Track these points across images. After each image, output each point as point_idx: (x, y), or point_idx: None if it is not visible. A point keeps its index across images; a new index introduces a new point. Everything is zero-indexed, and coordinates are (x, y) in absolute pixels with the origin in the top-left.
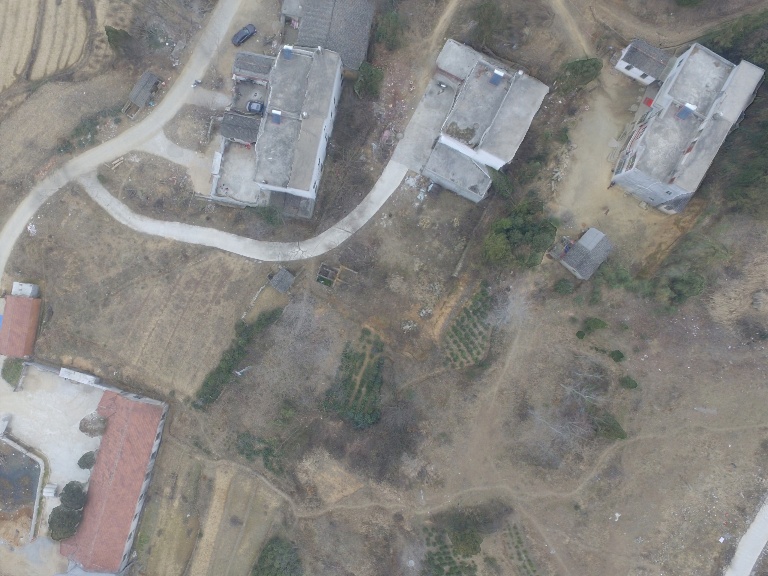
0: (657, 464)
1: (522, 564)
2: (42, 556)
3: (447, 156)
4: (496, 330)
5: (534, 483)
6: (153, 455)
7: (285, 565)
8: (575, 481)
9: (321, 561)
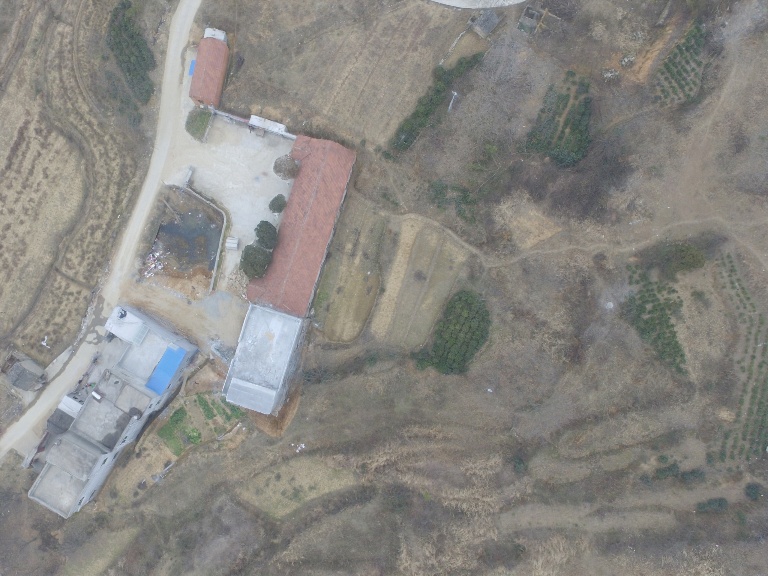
0: None
1: (735, 293)
2: (221, 308)
3: None
4: (709, 67)
5: (751, 210)
6: (341, 205)
7: (474, 314)
8: None
9: (510, 311)
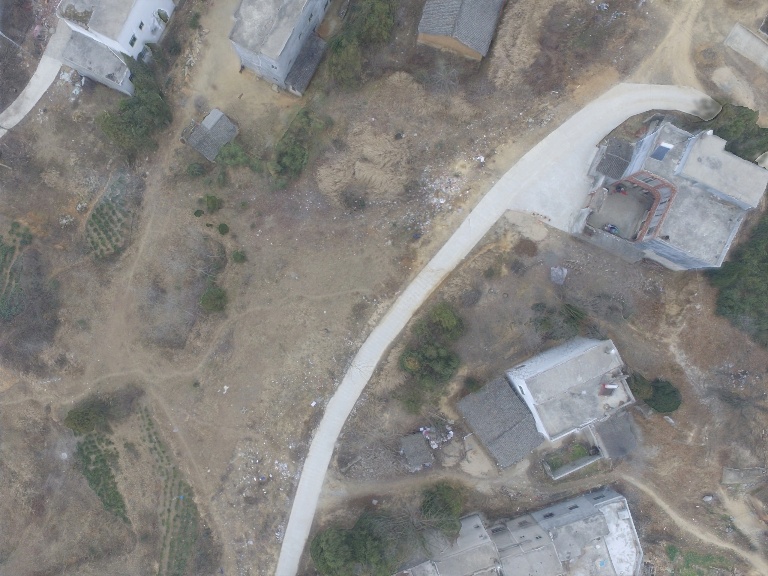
0: (262, 335)
1: (153, 446)
2: None
3: (83, 45)
4: (134, 217)
5: (161, 364)
6: None
7: None
8: (195, 359)
9: None
